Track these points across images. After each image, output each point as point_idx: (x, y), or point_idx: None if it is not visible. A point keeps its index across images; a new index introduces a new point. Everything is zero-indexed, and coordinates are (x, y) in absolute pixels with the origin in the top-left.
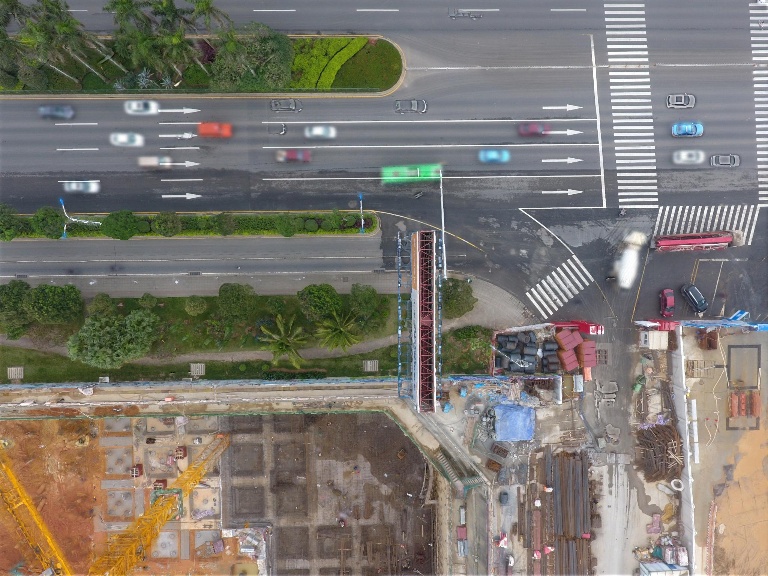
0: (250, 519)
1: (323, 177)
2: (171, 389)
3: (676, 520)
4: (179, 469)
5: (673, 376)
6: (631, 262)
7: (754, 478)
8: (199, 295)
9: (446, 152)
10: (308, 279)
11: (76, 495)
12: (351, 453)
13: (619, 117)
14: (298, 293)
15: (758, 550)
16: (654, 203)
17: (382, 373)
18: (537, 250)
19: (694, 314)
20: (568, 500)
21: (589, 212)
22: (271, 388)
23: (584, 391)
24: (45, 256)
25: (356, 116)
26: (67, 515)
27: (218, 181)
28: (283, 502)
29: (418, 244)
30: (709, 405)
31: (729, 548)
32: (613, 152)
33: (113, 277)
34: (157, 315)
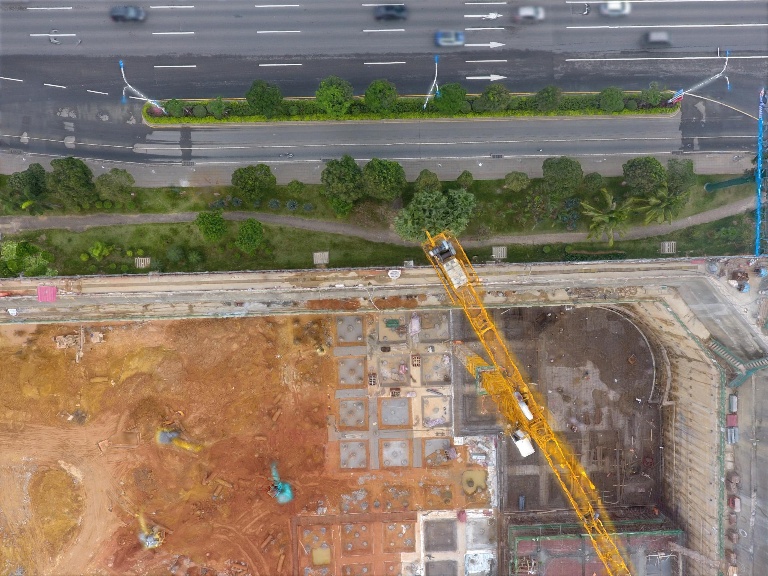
0: (481, 426)
1: (625, 57)
2: None
3: None
4: (412, 378)
5: None
6: None
7: None
8: (503, 178)
9: (746, 31)
10: (609, 161)
11: (311, 405)
12: (582, 359)
13: None
14: (626, 165)
15: None
16: None
17: (680, 254)
18: None
19: None
20: None
21: None
22: (573, 270)
23: None
24: (350, 140)
25: None
26: (304, 424)
27: (522, 62)
28: None
29: None
30: None
31: None
32: None
33: (417, 160)
34: None
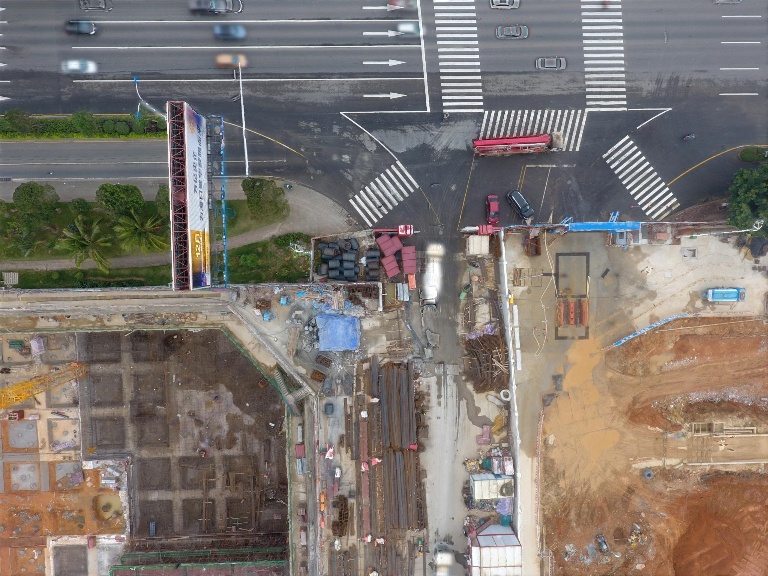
0: (111, 450)
1: (136, 79)
2: None
3: (506, 431)
4: (36, 400)
5: (501, 285)
6: (456, 168)
7: (584, 388)
8: (9, 201)
9: (263, 54)
10: None
11: None
12: (212, 382)
13: (441, 18)
14: (96, 191)
15: (588, 461)
16: (479, 107)
17: None
18: (360, 156)
19: (522, 222)
20: (392, 410)
21: (412, 116)
22: (86, 297)
23: (410, 300)
24: None
25: (169, 15)
26: None
27: (26, 83)
28: (145, 433)
29: (168, 115)
30: (537, 314)
31: (559, 459)
32: (436, 54)
33: None
34: None
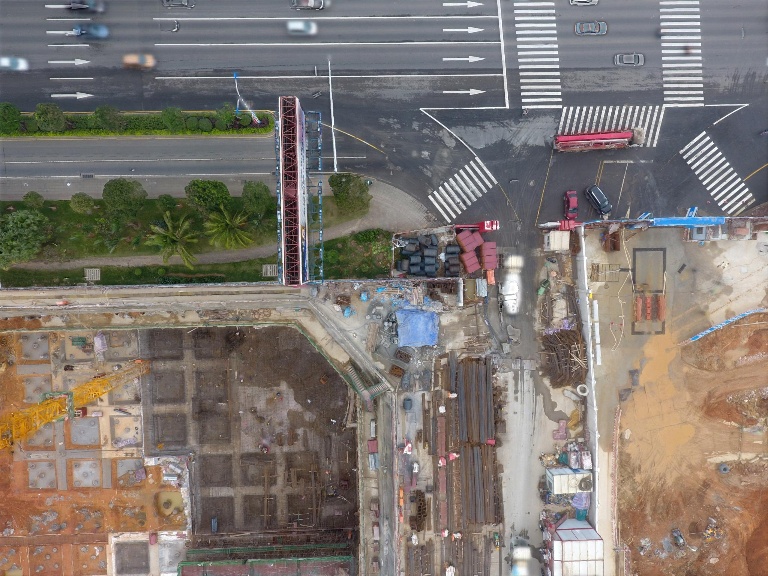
0: (172, 447)
1: (218, 76)
2: (65, 294)
3: (582, 426)
4: (99, 397)
5: (578, 280)
6: (535, 164)
7: (660, 383)
8: None
9: (344, 50)
10: None
11: None
12: (273, 379)
13: (521, 14)
14: (185, 188)
15: (664, 455)
16: (557, 103)
17: None
18: (439, 152)
19: (599, 217)
20: (471, 405)
21: (491, 112)
22: (168, 293)
23: (488, 296)
24: None
25: (251, 12)
26: None
27: (109, 80)
28: (206, 430)
29: (280, 110)
30: (614, 309)
31: (635, 453)
32: (515, 50)
33: (3, 179)
34: (46, 216)
